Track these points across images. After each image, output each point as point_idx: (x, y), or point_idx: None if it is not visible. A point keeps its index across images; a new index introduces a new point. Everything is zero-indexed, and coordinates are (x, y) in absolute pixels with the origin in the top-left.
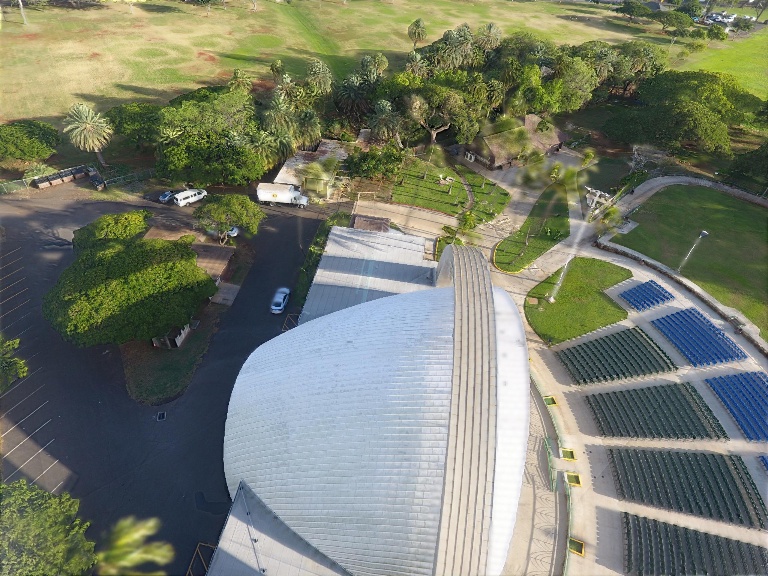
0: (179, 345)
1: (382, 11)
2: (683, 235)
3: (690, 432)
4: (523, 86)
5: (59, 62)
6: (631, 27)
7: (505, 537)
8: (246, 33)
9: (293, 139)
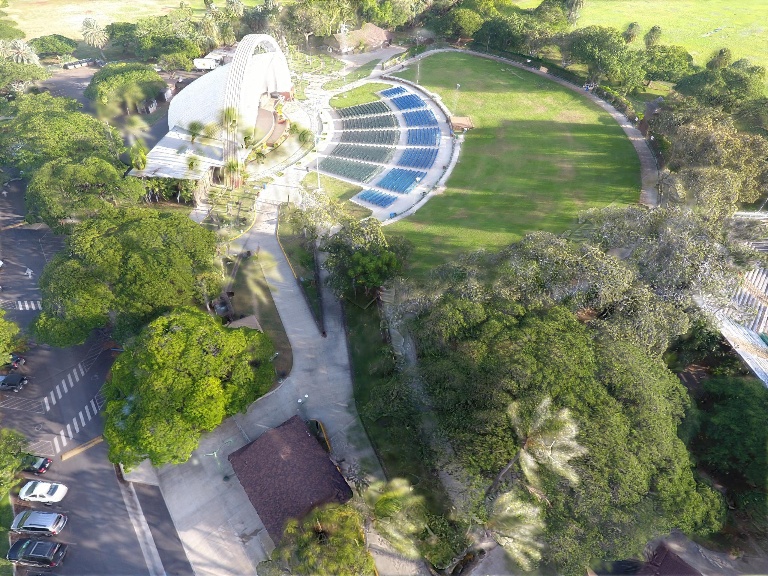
0: (151, 113)
1: None
2: (430, 71)
3: None
4: (365, 7)
5: (66, 16)
6: None
7: (257, 102)
8: None
9: (217, 39)
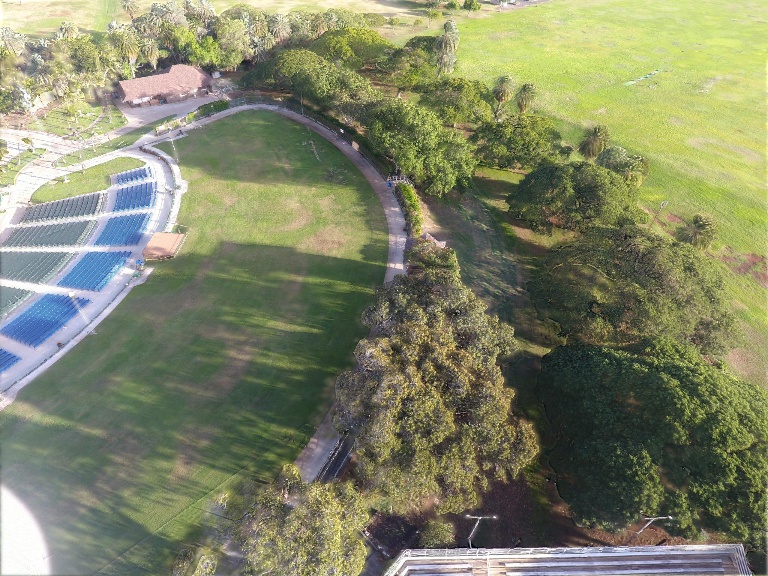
0: None
1: None
2: (211, 141)
3: (59, 242)
4: (180, 43)
5: None
6: (417, 3)
7: None
8: (42, 17)
9: None
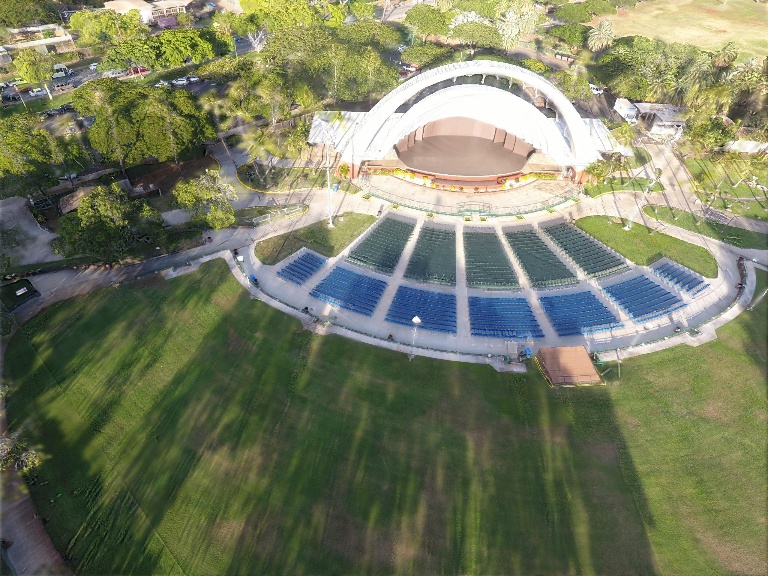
0: None
1: None
2: None
3: (528, 269)
4: None
5: (691, 26)
6: None
7: None
8: None
9: (694, 96)
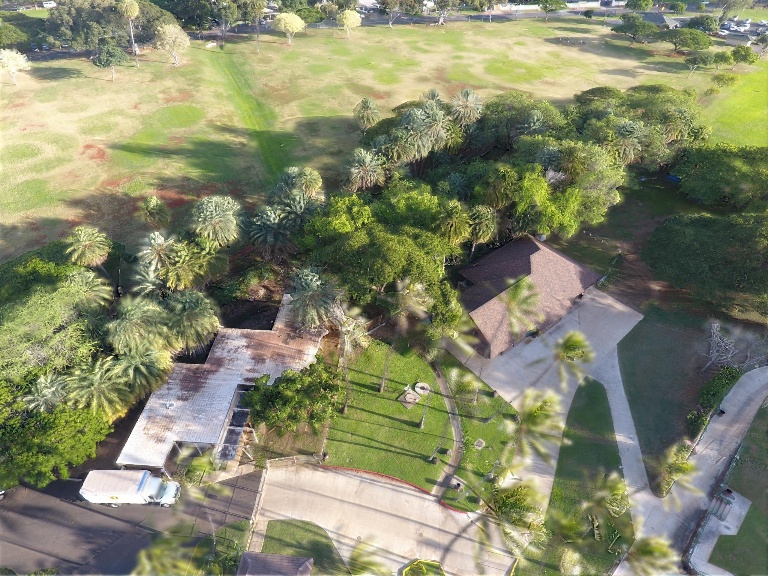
0: None
1: (334, 51)
2: None
3: None
4: (522, 204)
5: None
6: (635, 49)
7: None
8: (157, 104)
9: (165, 349)
